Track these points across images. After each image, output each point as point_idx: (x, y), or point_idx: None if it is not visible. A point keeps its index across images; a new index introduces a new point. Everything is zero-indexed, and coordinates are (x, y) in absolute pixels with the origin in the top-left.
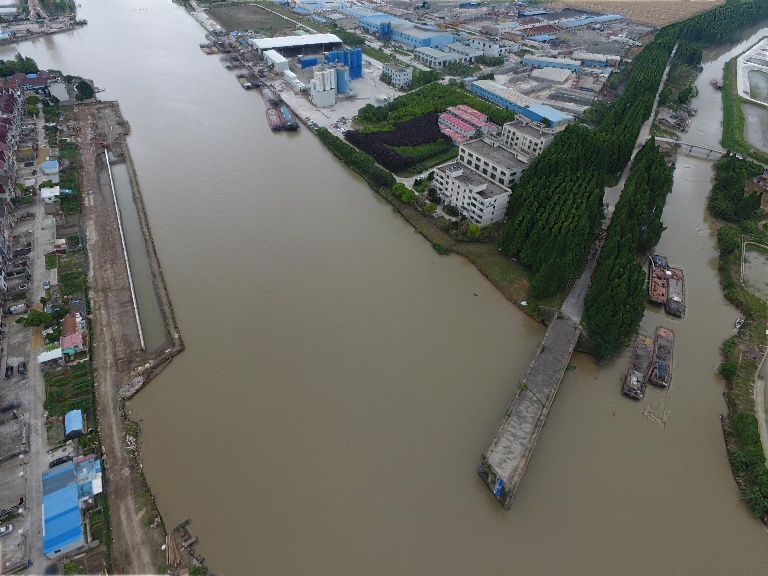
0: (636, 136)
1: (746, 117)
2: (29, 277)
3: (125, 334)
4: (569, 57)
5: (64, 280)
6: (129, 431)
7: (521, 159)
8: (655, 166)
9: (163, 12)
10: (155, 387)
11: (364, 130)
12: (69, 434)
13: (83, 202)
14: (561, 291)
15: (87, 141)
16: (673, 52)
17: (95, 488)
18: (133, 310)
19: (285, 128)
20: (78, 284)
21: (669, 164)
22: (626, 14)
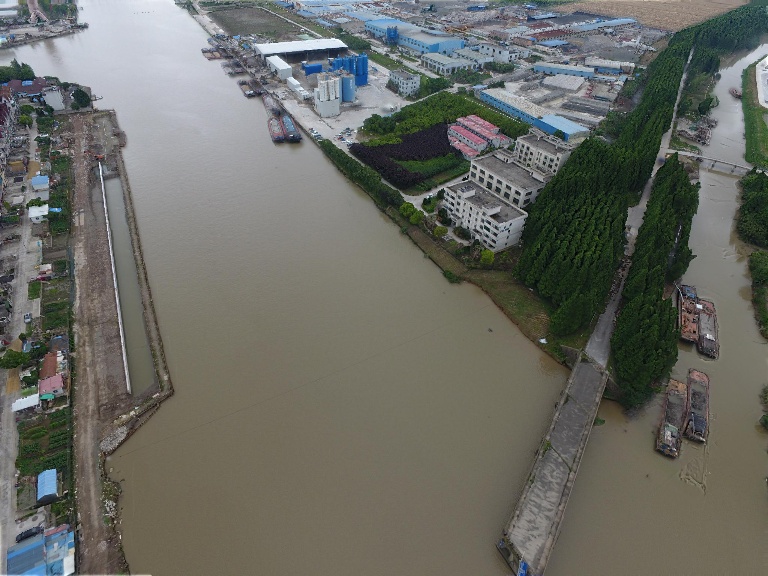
0: (657, 151)
1: None
2: (10, 308)
3: (110, 375)
4: (582, 64)
5: (47, 312)
6: (109, 494)
7: (537, 177)
8: (680, 186)
9: (166, 15)
10: (140, 440)
11: (370, 143)
12: (41, 499)
13: (73, 222)
14: (584, 328)
15: (81, 154)
16: (689, 58)
17: (66, 568)
18: (120, 347)
19: (287, 140)
20: (62, 316)
21: (692, 181)
22: (638, 18)
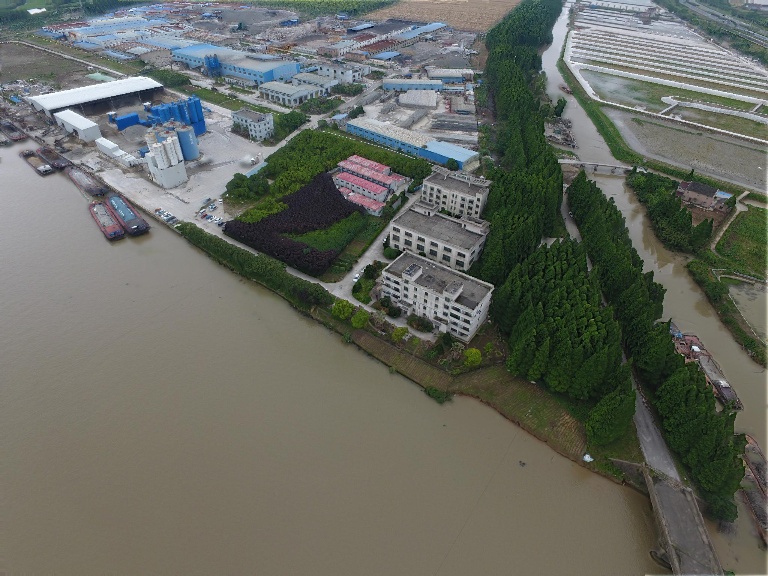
0: None
1: (613, 122)
2: None
3: None
4: (425, 75)
5: None
6: None
7: (471, 230)
8: (605, 208)
9: None
10: None
11: (250, 219)
12: None
13: None
14: None
15: None
16: None
17: None
18: None
19: (130, 233)
20: None
21: None
22: (443, 21)
